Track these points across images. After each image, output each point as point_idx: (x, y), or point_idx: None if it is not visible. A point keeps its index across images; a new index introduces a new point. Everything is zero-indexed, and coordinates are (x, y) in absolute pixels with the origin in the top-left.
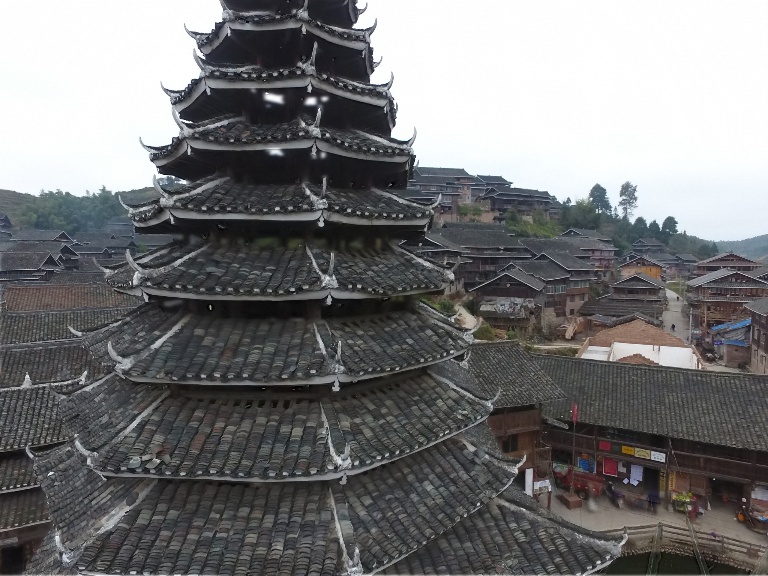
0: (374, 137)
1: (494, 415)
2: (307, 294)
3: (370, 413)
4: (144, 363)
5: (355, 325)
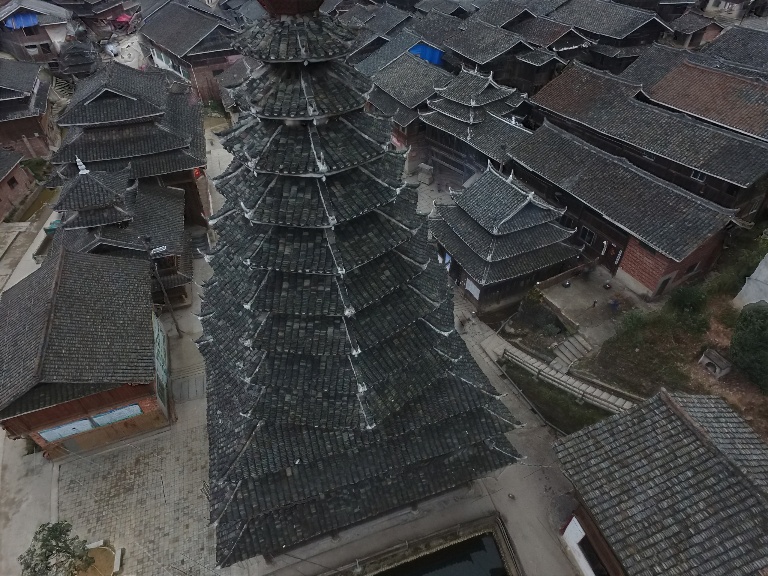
0: None
1: None
2: None
3: None
4: None
5: None
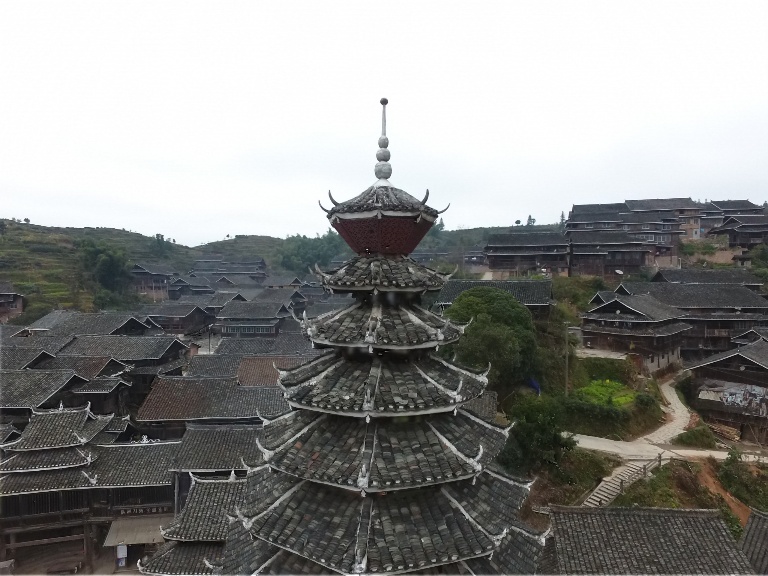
0: (444, 439)
1: None
2: None
3: None
4: None
5: None
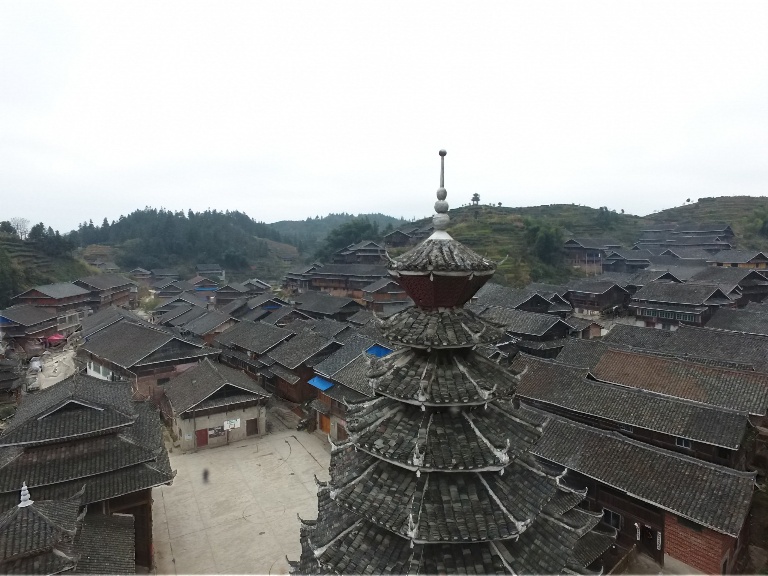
0: None
1: None
2: None
3: None
4: (296, 574)
5: None
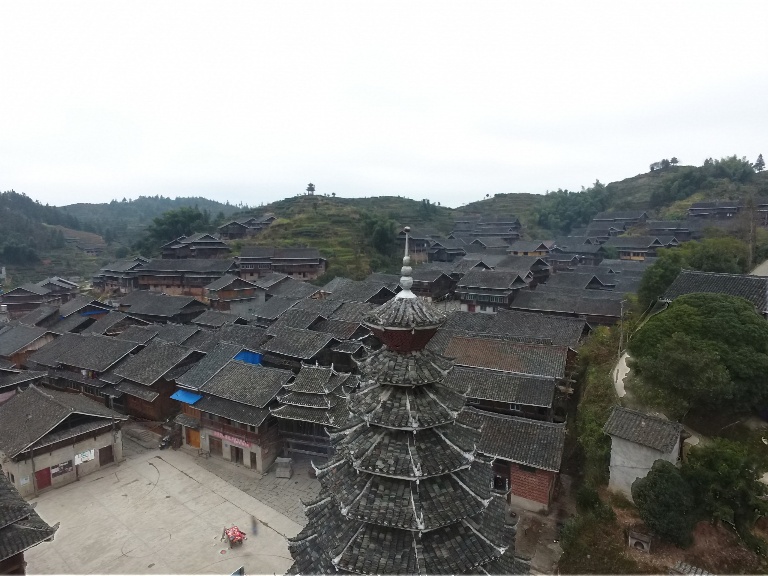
0: (412, 497)
1: None
2: None
3: None
4: None
5: None
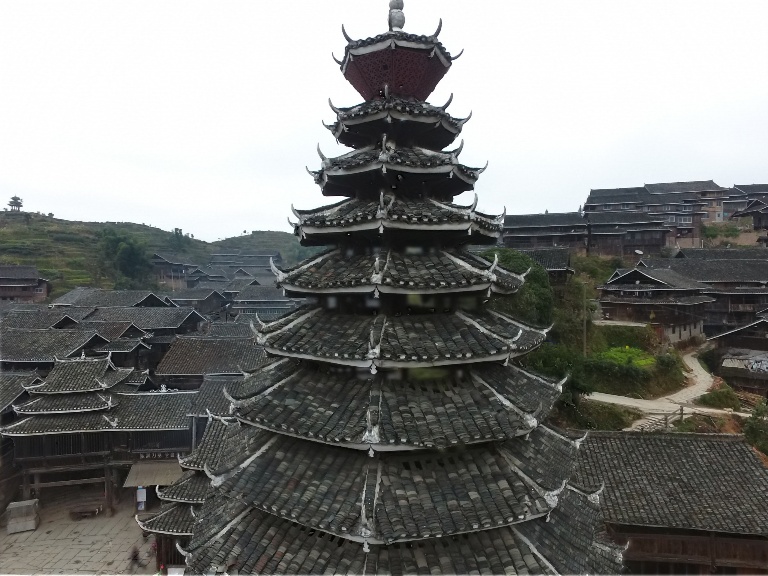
0: (458, 260)
1: (694, 535)
2: (351, 445)
3: (417, 571)
4: (231, 482)
5: (417, 467)
